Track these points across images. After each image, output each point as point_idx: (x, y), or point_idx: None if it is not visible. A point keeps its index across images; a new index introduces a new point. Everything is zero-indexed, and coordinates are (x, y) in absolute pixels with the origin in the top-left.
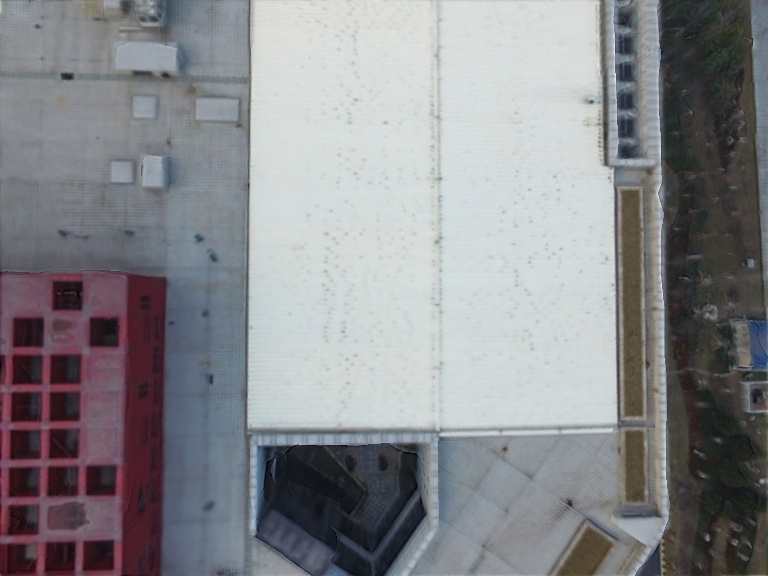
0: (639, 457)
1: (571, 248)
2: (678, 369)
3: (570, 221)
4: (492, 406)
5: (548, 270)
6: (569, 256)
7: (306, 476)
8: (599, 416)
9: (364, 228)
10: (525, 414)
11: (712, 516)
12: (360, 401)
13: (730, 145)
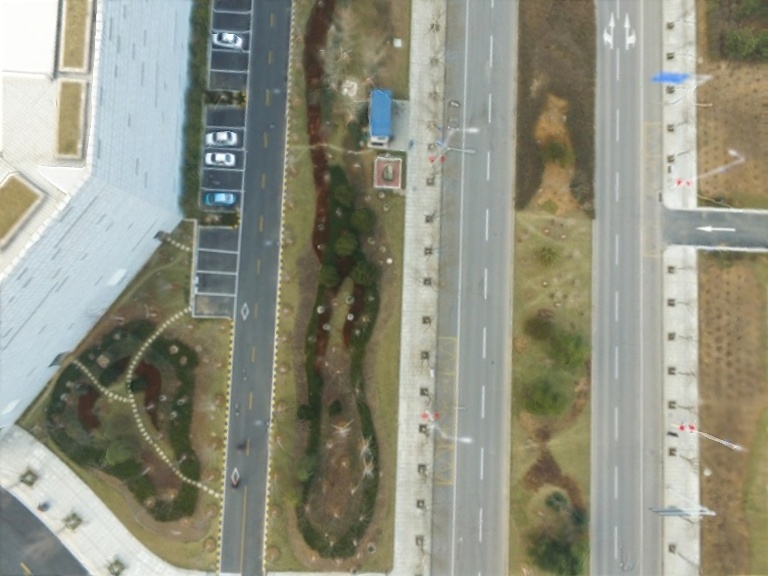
0: (74, 108)
1: None
2: (311, 144)
3: None
4: None
5: None
6: None
7: None
8: (32, 63)
9: None
10: None
11: (328, 289)
12: None
13: None
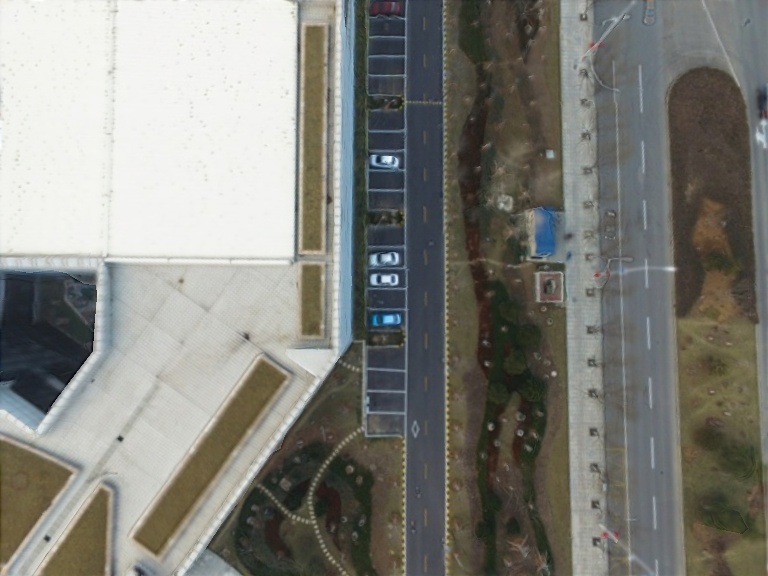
0: (315, 291)
1: (250, 82)
2: (470, 259)
3: (250, 55)
4: (163, 235)
5: (225, 102)
6: (247, 89)
7: (58, 341)
8: (275, 249)
9: (40, 59)
10: (197, 244)
11: (497, 406)
12: (30, 227)
13: (529, 34)
